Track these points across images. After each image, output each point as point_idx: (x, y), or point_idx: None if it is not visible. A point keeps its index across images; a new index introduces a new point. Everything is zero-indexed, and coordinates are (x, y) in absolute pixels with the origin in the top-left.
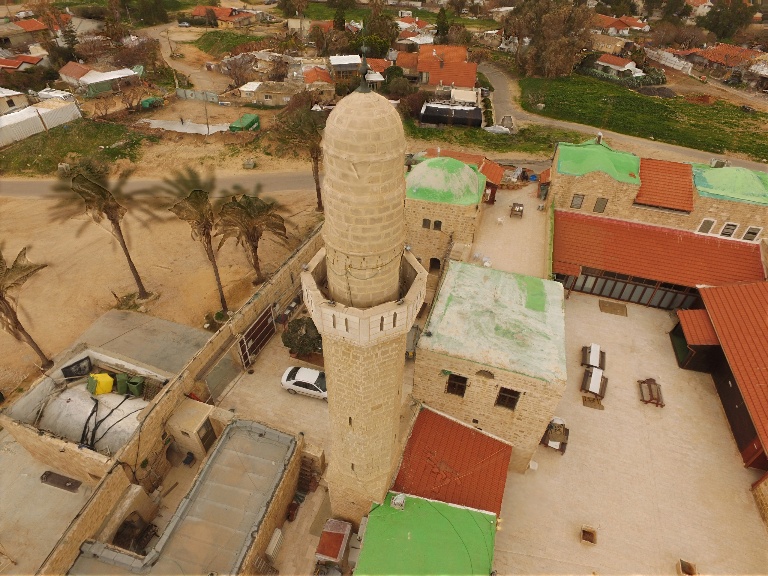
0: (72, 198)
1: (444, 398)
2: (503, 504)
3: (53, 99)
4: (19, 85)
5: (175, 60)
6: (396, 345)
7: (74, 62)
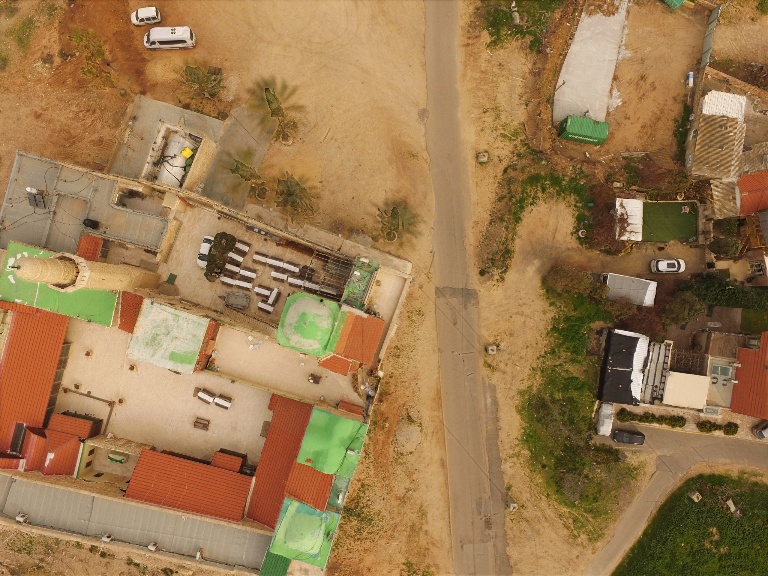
0: (426, 22)
1: None
2: None
3: None
4: None
5: None
6: None
7: None
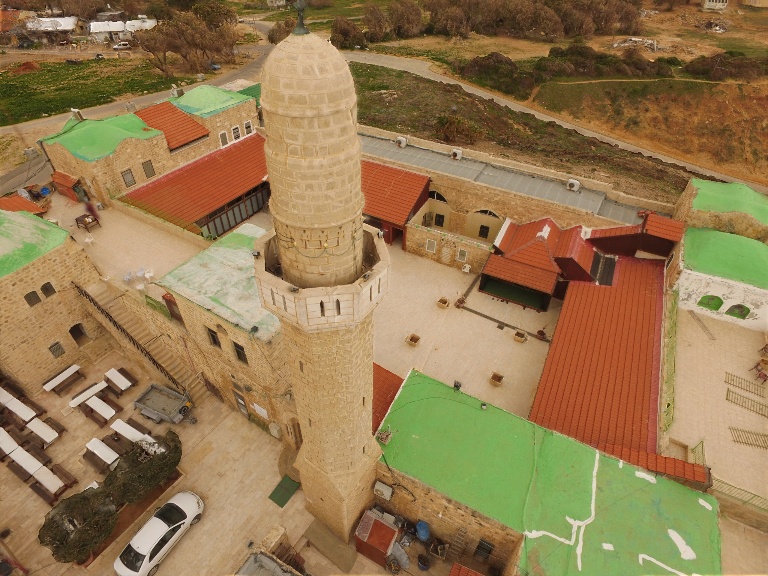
0: None
1: None
2: None
3: None
4: None
5: None
6: None
7: None
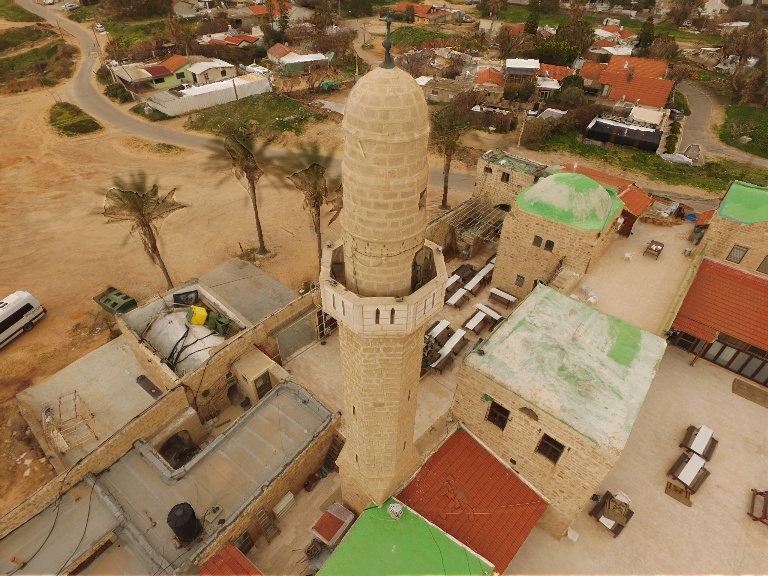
0: None
1: (484, 425)
2: (522, 562)
3: (254, 73)
4: (235, 59)
5: (365, 50)
6: (401, 345)
7: (281, 44)
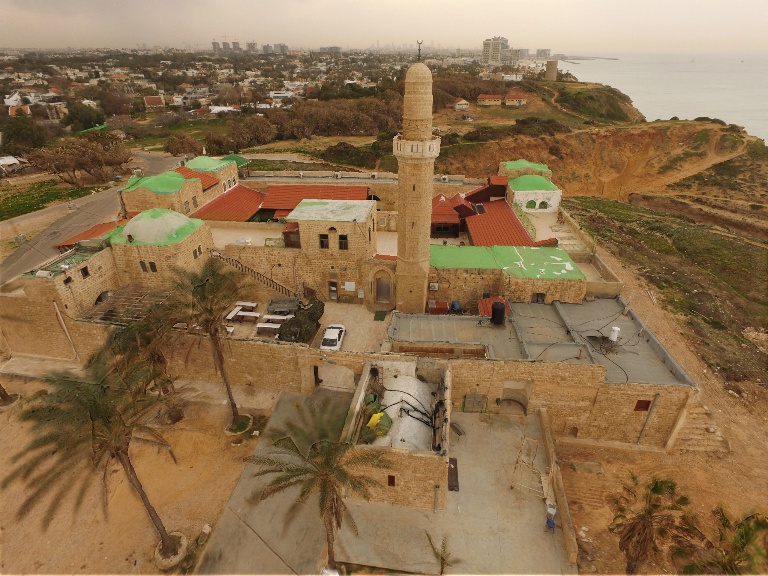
0: None
1: None
2: None
3: None
4: None
5: None
6: None
7: None
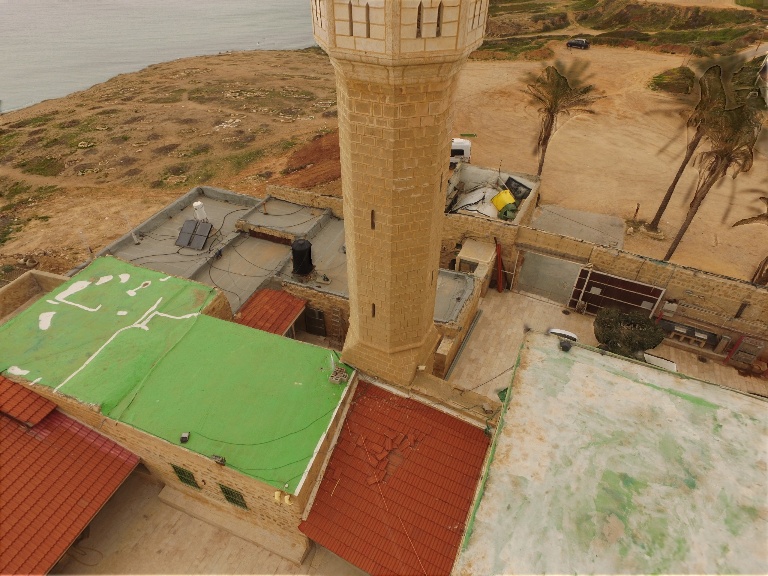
0: None
1: None
2: None
3: None
4: None
5: None
6: None
7: None
